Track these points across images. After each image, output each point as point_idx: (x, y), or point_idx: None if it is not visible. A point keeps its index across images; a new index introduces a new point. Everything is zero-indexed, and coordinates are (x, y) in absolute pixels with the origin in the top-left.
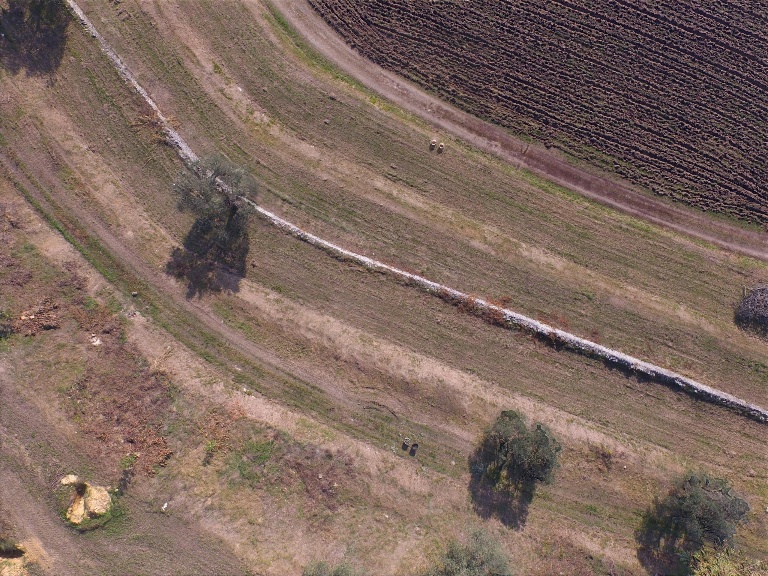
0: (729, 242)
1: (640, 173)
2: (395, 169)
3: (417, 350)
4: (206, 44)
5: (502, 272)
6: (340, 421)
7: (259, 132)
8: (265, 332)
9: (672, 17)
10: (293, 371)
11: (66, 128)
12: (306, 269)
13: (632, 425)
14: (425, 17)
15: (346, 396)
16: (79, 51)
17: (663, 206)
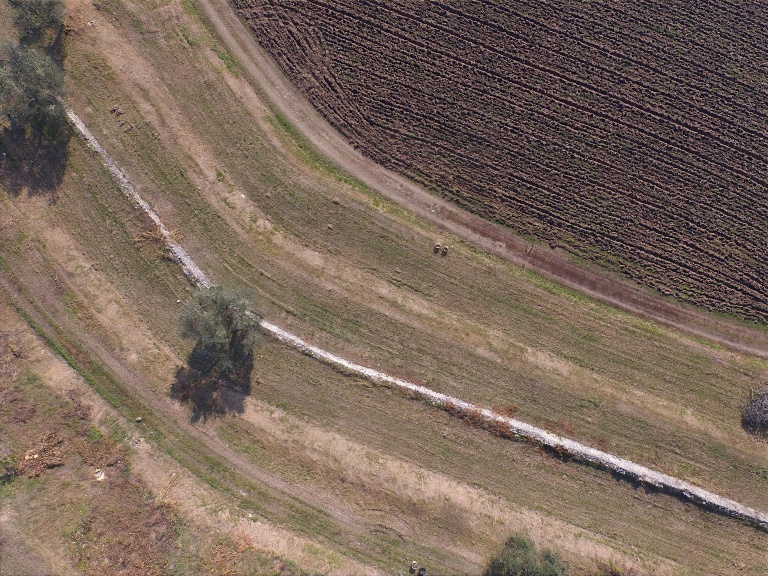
0: (735, 342)
1: (645, 273)
2: (399, 273)
3: (423, 465)
4: (209, 150)
5: (508, 380)
6: (347, 545)
7: (263, 241)
8: (270, 455)
9: (676, 116)
10: (299, 495)
11: (69, 247)
12: (311, 385)
13: (640, 537)
14: (428, 117)
15: (353, 520)
16: (81, 167)
17: (669, 306)
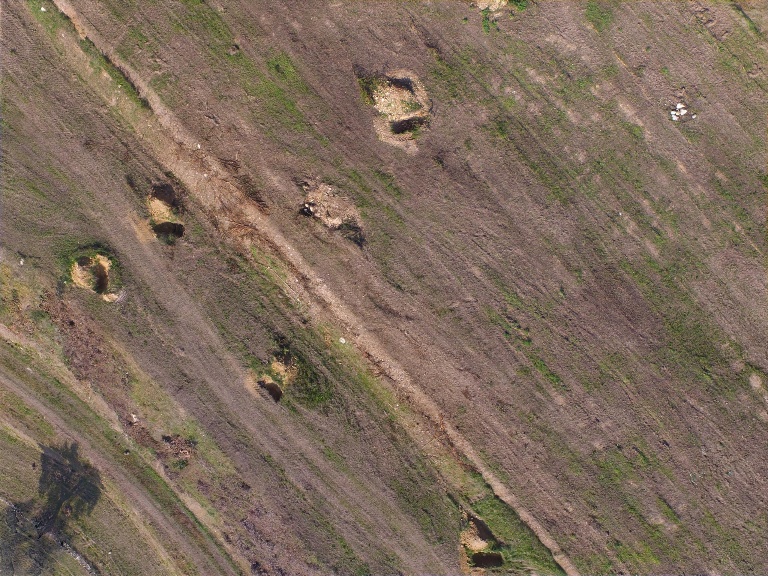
0: None
1: None
2: None
3: None
4: None
5: None
6: None
7: None
8: (6, 403)
9: None
10: None
11: None
12: None
13: None
14: None
15: None
16: None
17: None
